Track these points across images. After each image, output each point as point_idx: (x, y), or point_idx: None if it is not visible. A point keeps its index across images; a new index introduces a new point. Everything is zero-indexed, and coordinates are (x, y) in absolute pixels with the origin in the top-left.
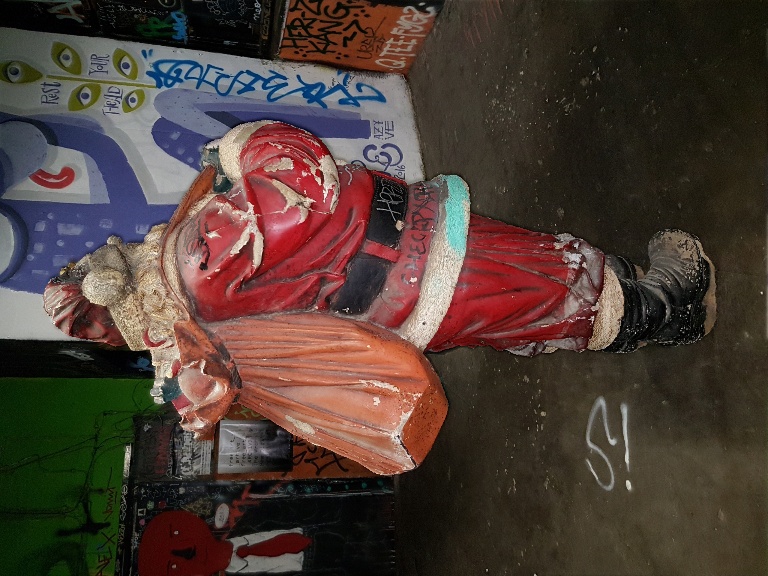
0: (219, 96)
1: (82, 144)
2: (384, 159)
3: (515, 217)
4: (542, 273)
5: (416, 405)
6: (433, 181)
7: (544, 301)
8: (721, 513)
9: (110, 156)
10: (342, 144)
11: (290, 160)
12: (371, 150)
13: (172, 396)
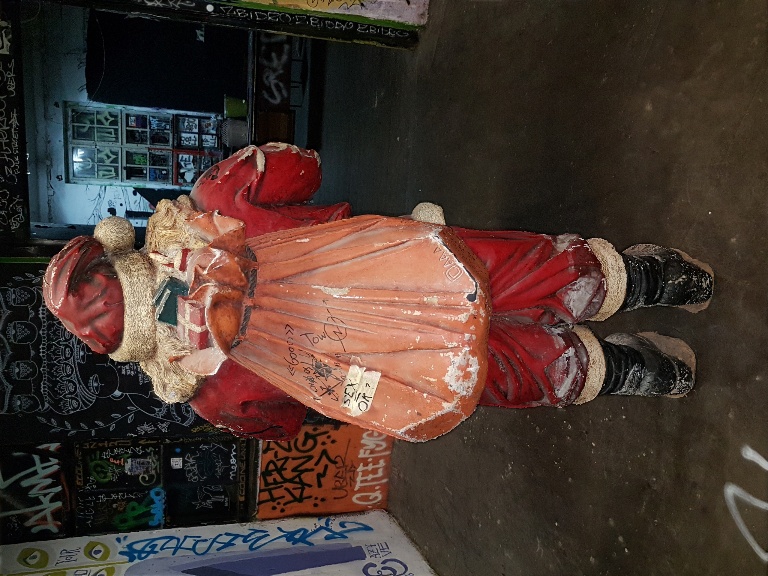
0: (197, 556)
1: None
2: (388, 572)
3: (532, 473)
4: None
5: (444, 229)
6: None
7: (535, 245)
8: None
9: None
10: (337, 569)
11: None
12: (371, 568)
13: (179, 293)
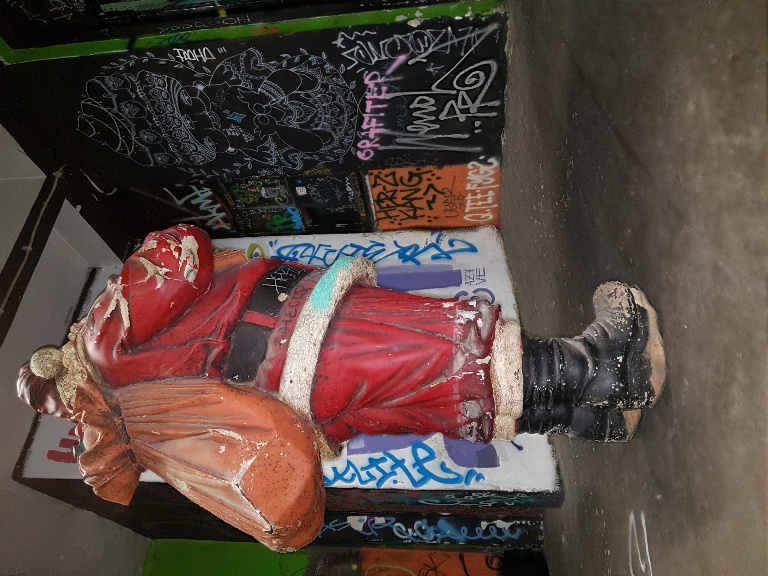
0: None
1: None
2: None
3: (562, 328)
4: (426, 331)
5: (259, 454)
6: None
7: (427, 358)
8: None
9: None
10: (434, 294)
11: (156, 242)
12: (462, 296)
13: None
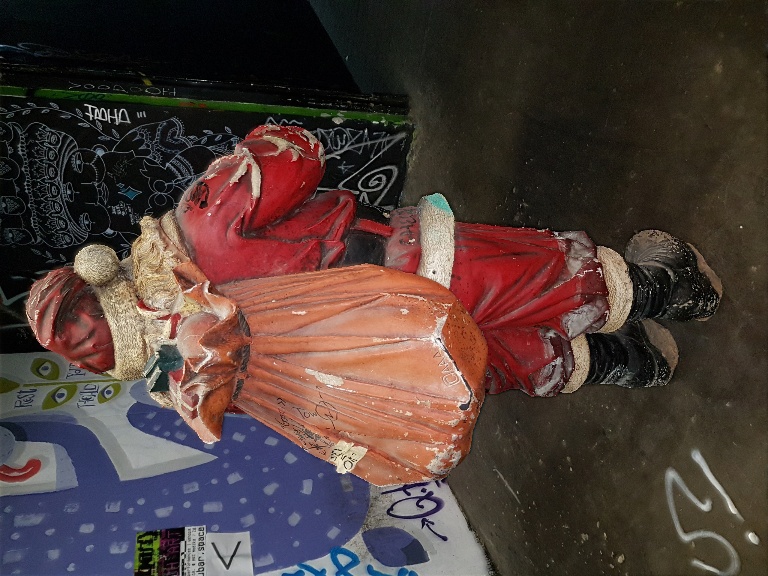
0: None
1: (53, 435)
2: None
3: None
4: (534, 245)
5: (449, 313)
6: None
7: (546, 263)
8: None
9: (82, 442)
10: None
11: (277, 127)
12: None
13: (169, 368)
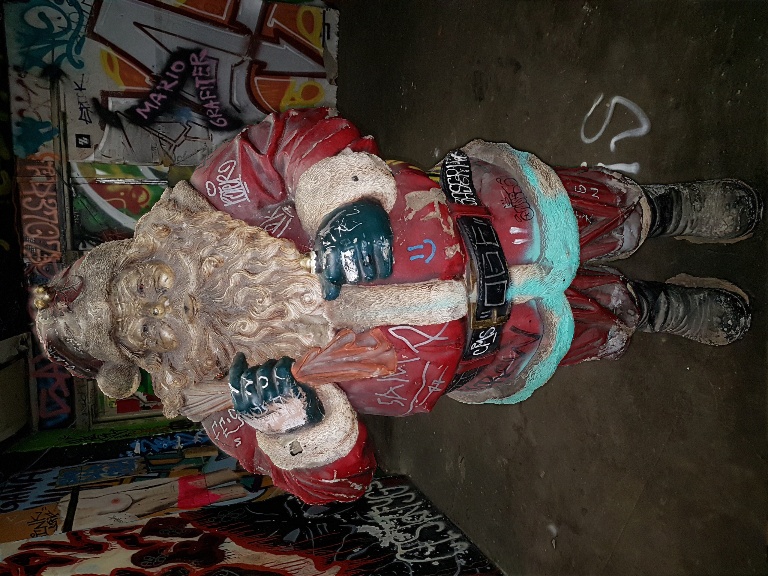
0: None
1: None
2: None
3: None
4: None
5: None
6: (541, 341)
7: None
8: None
9: None
10: None
11: None
12: None
13: None
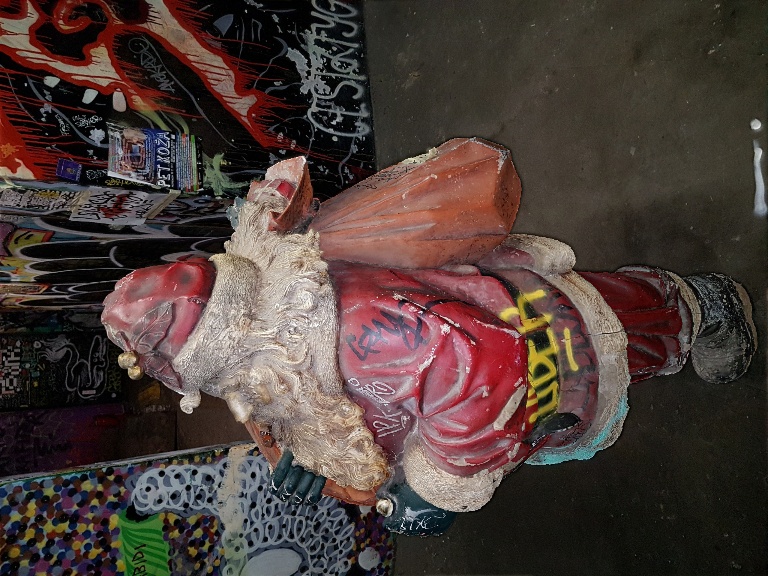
0: None
1: None
2: None
3: None
4: None
5: None
6: None
7: None
8: (632, 153)
9: None
10: None
11: None
12: None
13: None
